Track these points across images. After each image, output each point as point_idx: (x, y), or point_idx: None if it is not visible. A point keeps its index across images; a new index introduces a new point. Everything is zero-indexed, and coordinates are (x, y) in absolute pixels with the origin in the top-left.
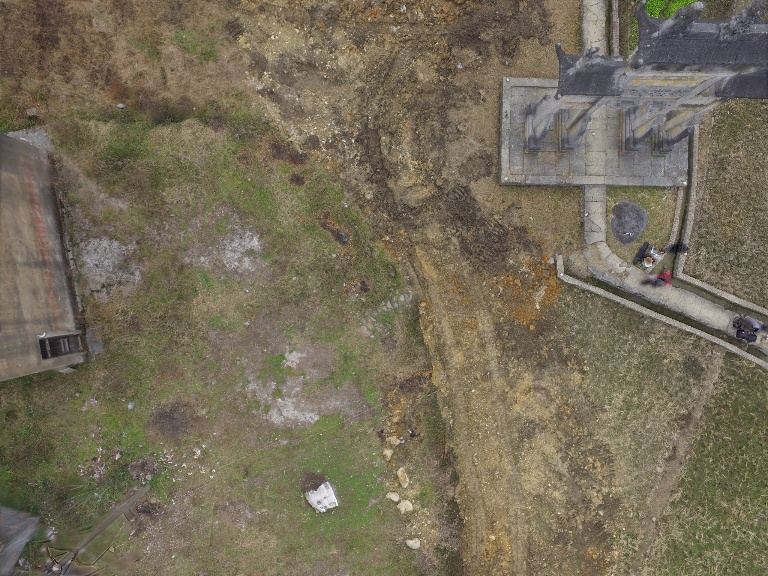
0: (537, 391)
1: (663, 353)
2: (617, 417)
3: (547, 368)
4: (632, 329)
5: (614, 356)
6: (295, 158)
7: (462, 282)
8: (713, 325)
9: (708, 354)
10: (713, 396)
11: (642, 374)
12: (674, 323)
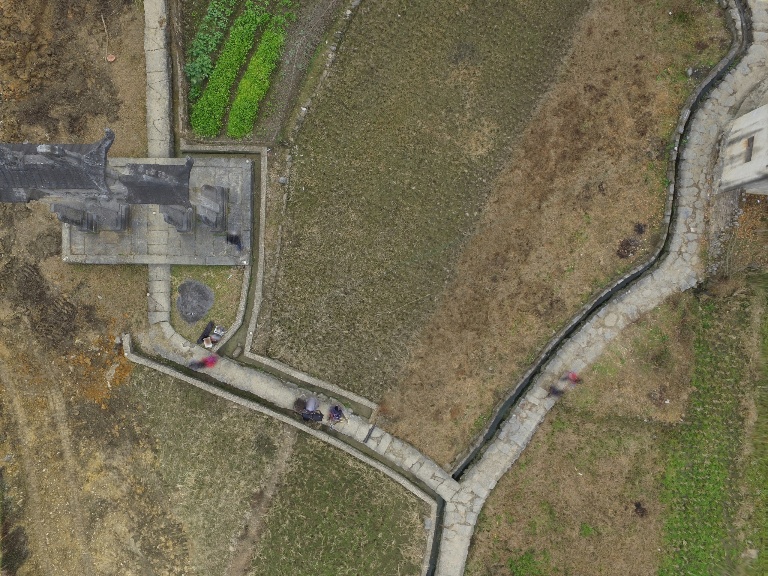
0: (109, 470)
1: (235, 432)
2: (189, 496)
3: (119, 447)
4: (205, 407)
5: (187, 435)
6: None
7: (30, 361)
8: (279, 404)
9: (280, 432)
10: (288, 474)
11: (215, 453)
12: (241, 402)
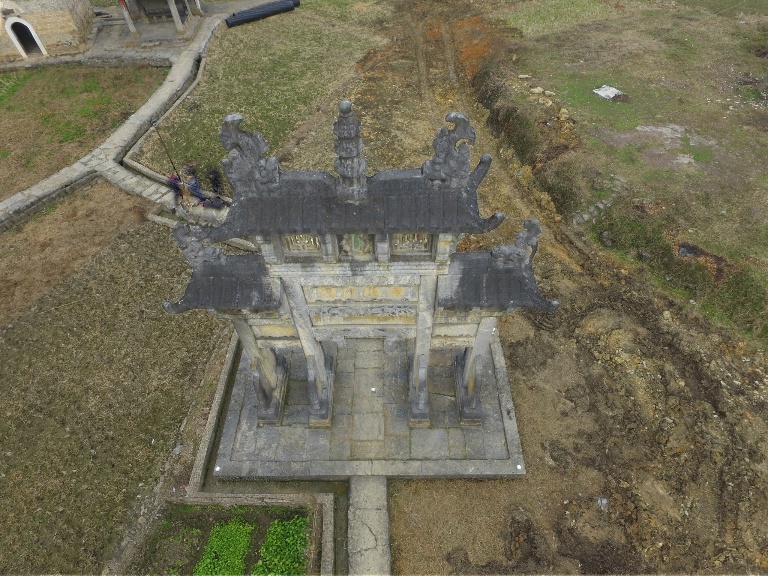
0: None
1: None
2: None
3: None
4: None
5: None
6: None
7: None
8: None
9: None
10: None
11: None
12: None
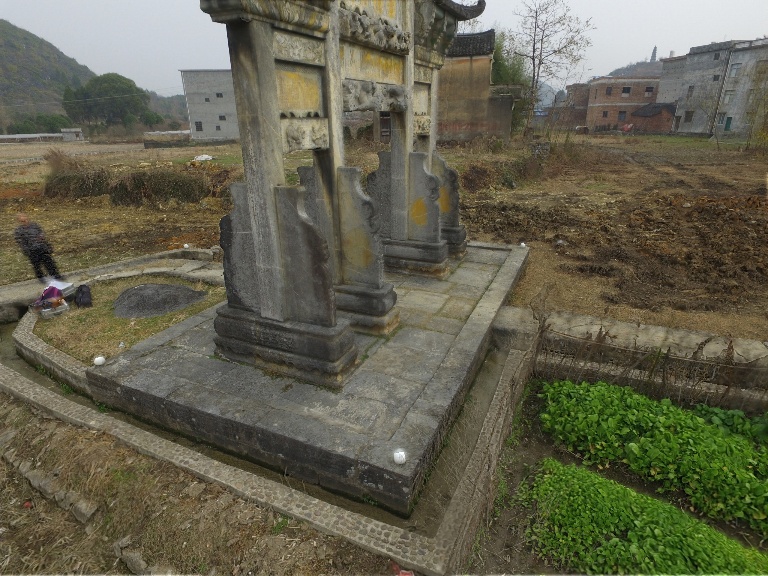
0: None
1: None
2: None
3: None
4: None
5: (8, 271)
6: (471, 184)
7: None
8: None
9: None
10: None
11: None
12: None
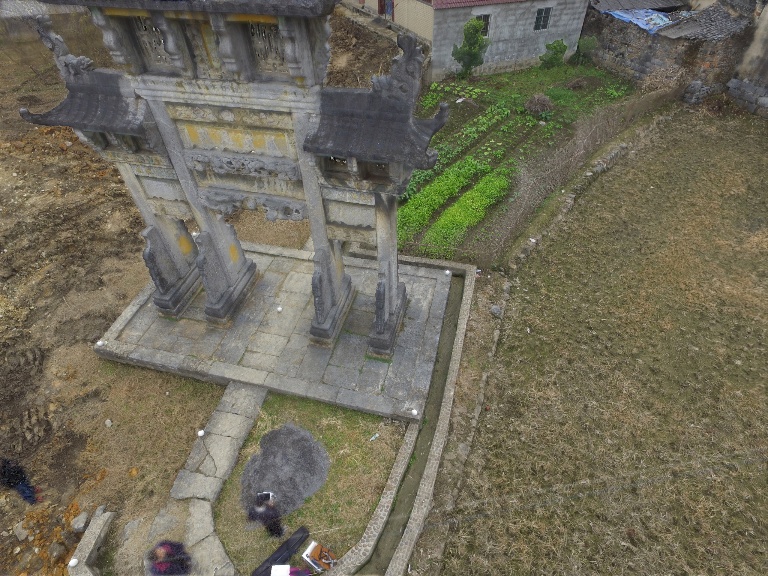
0: None
1: None
2: None
3: None
4: None
5: None
6: None
7: None
8: None
9: None
10: None
11: None
12: None
